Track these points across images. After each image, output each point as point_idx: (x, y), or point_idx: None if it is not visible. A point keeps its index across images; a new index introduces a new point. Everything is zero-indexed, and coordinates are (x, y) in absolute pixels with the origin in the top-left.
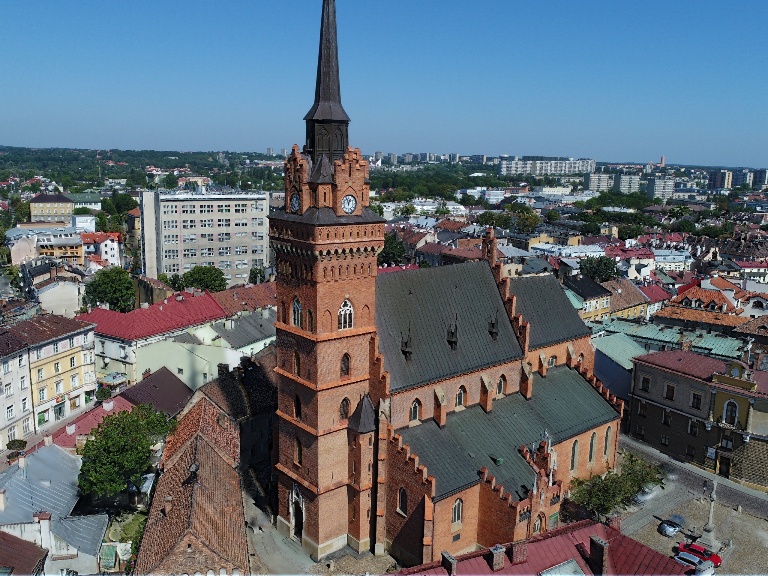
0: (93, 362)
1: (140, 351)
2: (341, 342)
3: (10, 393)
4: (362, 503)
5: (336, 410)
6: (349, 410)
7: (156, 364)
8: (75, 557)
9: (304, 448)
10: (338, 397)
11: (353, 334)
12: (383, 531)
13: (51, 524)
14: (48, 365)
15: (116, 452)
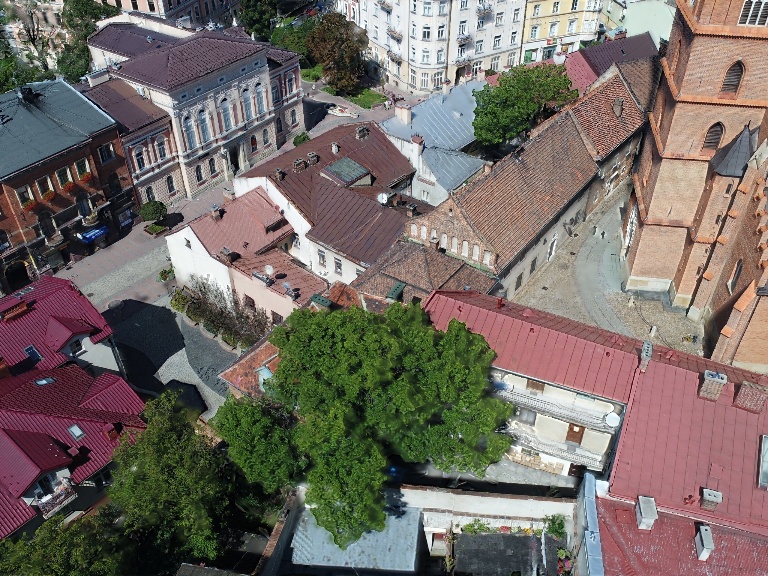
0: (597, 10)
1: (631, 7)
2: (736, 43)
3: (501, 23)
4: (693, 255)
5: (699, 134)
6: (721, 140)
7: (642, 26)
8: (434, 185)
9: (652, 166)
10: (707, 118)
11: (759, 35)
12: (705, 297)
13: (425, 149)
14: (547, 2)
15: (499, 104)
